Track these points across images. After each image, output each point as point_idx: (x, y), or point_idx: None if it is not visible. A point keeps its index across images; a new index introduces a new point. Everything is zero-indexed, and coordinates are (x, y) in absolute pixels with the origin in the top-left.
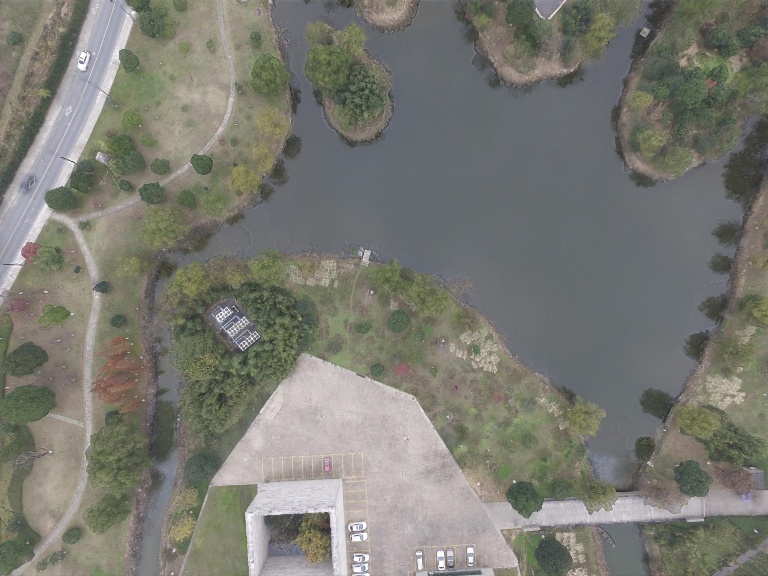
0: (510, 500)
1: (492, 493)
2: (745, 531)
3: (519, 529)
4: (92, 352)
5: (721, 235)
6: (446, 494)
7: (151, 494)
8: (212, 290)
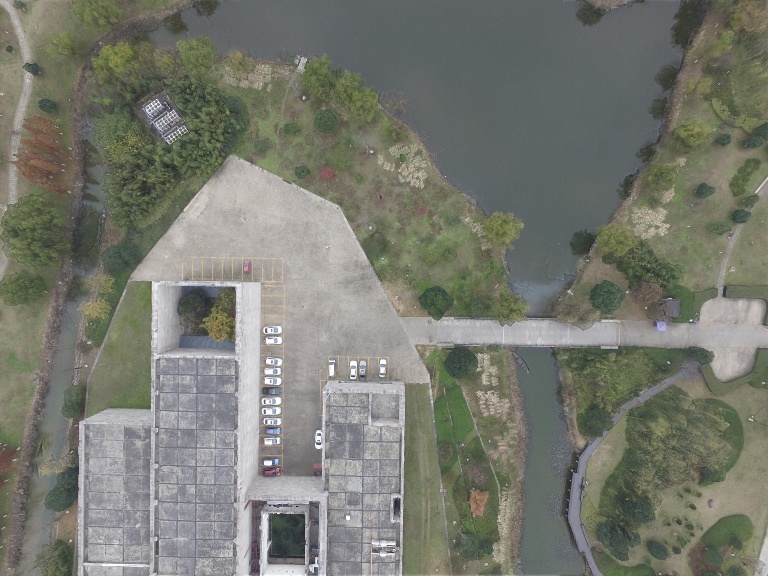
0: (421, 300)
1: (409, 308)
2: (658, 361)
3: (434, 346)
4: (20, 136)
5: (665, 84)
6: (363, 305)
7: (71, 288)
8: (142, 77)
